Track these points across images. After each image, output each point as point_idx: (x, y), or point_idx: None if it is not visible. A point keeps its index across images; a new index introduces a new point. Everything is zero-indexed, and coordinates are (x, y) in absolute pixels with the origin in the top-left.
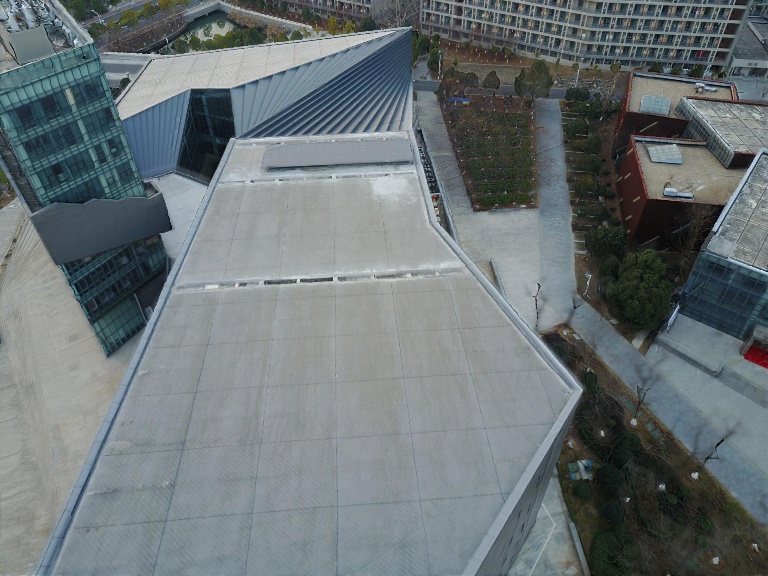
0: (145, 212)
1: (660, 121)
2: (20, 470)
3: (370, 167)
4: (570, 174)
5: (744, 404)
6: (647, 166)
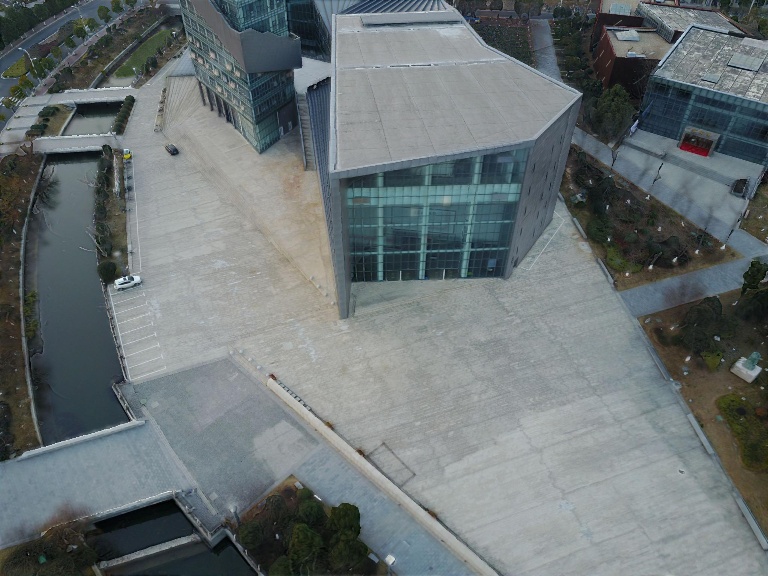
0: (291, 49)
1: (624, 19)
2: (223, 207)
3: (434, 25)
4: (560, 62)
5: (679, 170)
6: (615, 42)
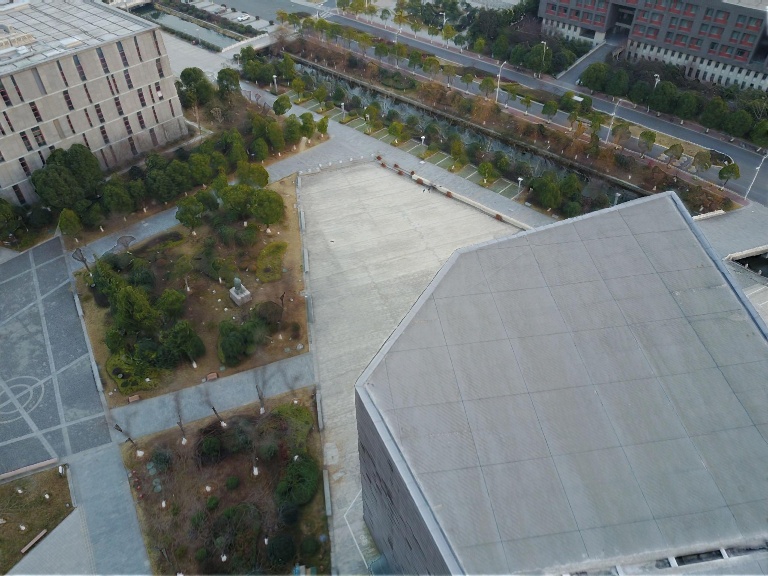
0: None
1: None
2: None
3: None
4: None
5: None
6: None
